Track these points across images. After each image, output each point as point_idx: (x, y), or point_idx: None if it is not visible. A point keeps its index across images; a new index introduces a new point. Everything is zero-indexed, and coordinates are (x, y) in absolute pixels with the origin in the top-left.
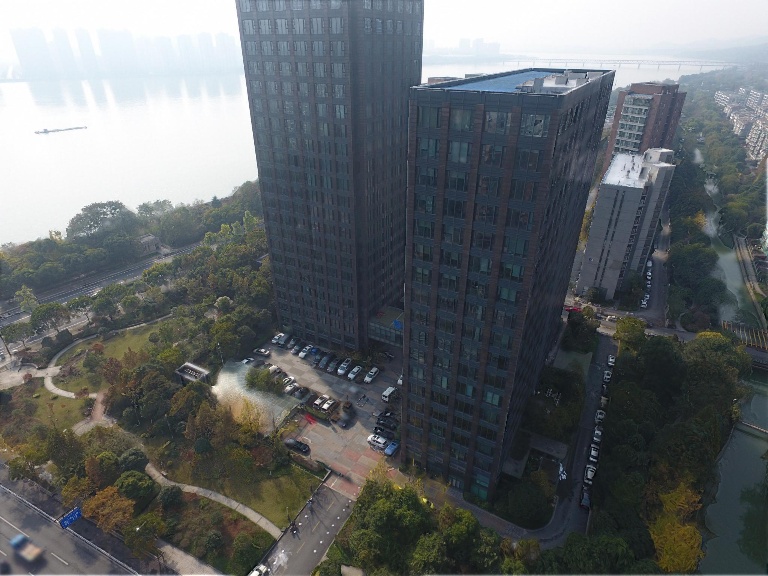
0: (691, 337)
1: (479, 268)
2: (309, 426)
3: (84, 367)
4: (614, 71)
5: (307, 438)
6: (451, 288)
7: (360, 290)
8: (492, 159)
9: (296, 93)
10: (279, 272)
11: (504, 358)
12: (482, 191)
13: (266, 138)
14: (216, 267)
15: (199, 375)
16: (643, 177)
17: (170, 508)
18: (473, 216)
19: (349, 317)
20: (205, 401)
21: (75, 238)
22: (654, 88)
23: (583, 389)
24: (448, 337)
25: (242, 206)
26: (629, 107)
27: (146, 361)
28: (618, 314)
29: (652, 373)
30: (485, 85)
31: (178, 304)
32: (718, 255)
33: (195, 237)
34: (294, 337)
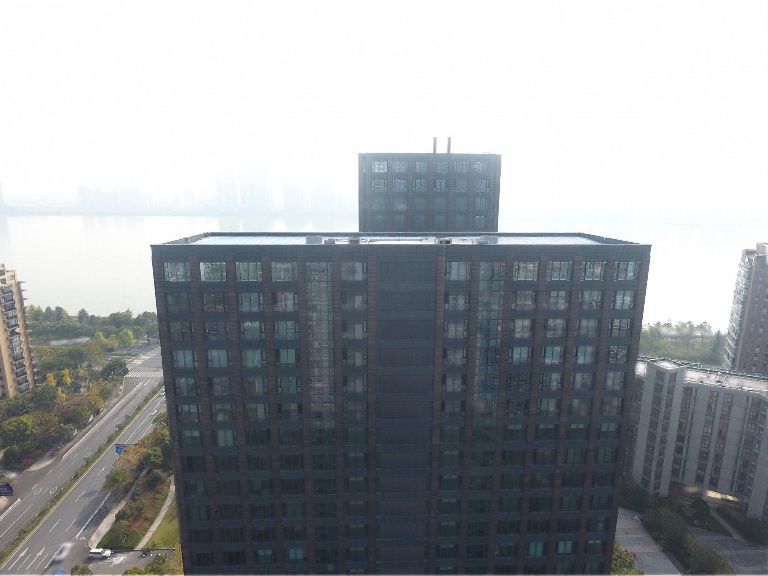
0: None
1: None
2: None
3: None
4: (618, 245)
5: None
6: None
7: None
8: None
9: None
10: None
11: None
12: None
13: None
14: None
15: None
16: None
17: (147, 484)
18: None
19: None
20: None
21: None
22: None
23: None
24: None
25: None
26: None
27: None
28: None
29: None
30: None
31: None
32: None
33: None
34: None
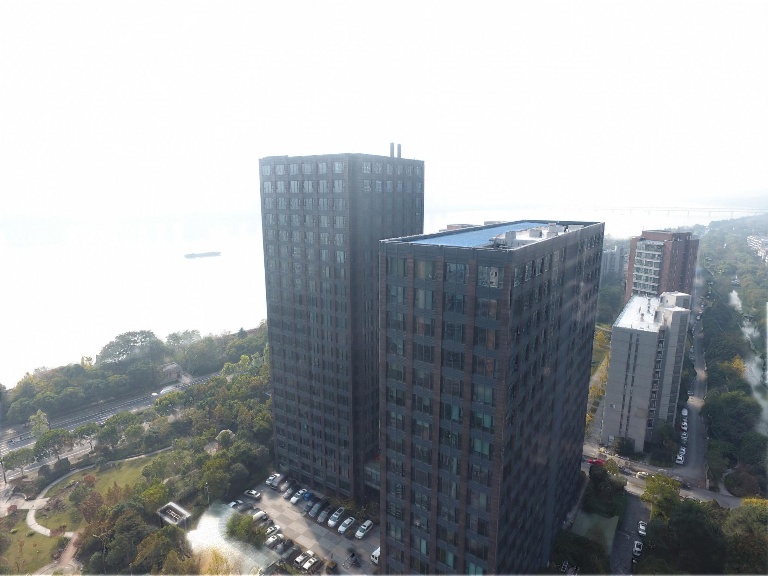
0: (738, 503)
1: (451, 416)
2: None
3: (70, 501)
4: (602, 223)
5: None
6: (425, 436)
7: (356, 430)
8: (455, 307)
9: (303, 240)
10: (279, 407)
11: (484, 521)
12: (448, 337)
13: (276, 278)
14: (225, 398)
15: (180, 518)
16: (658, 321)
17: None
18: (441, 361)
19: (345, 459)
20: (176, 550)
21: (103, 364)
22: (664, 235)
23: (606, 564)
24: (424, 492)
25: (266, 338)
26: (642, 252)
27: (130, 498)
28: (650, 470)
29: (687, 548)
30: (462, 237)
31: (182, 435)
32: (761, 406)
33: (216, 366)
34: (289, 478)
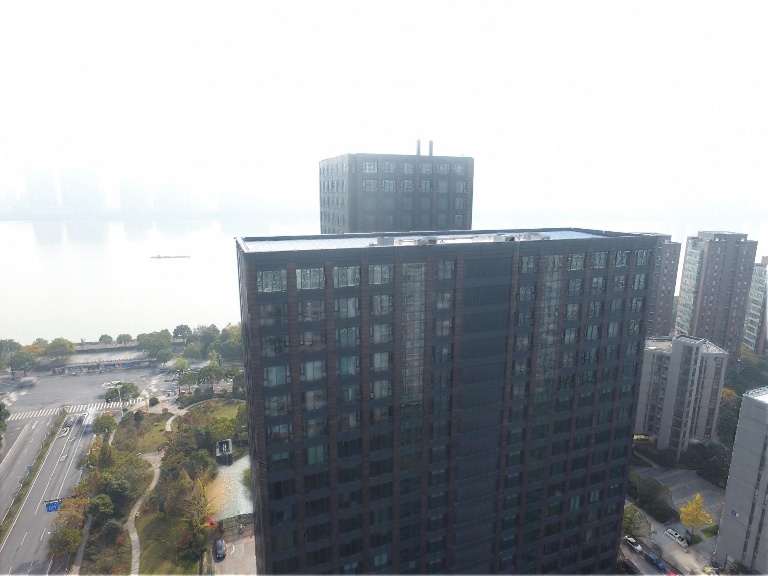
0: None
1: None
2: (247, 538)
3: None
4: (638, 237)
5: (234, 548)
6: None
7: None
8: None
9: None
10: None
11: None
12: None
13: None
14: None
15: (225, 452)
16: None
17: (103, 539)
18: (247, 358)
19: None
20: None
21: None
22: None
23: None
24: None
25: None
26: None
27: None
28: None
29: None
30: (363, 240)
31: None
32: None
33: None
34: None
